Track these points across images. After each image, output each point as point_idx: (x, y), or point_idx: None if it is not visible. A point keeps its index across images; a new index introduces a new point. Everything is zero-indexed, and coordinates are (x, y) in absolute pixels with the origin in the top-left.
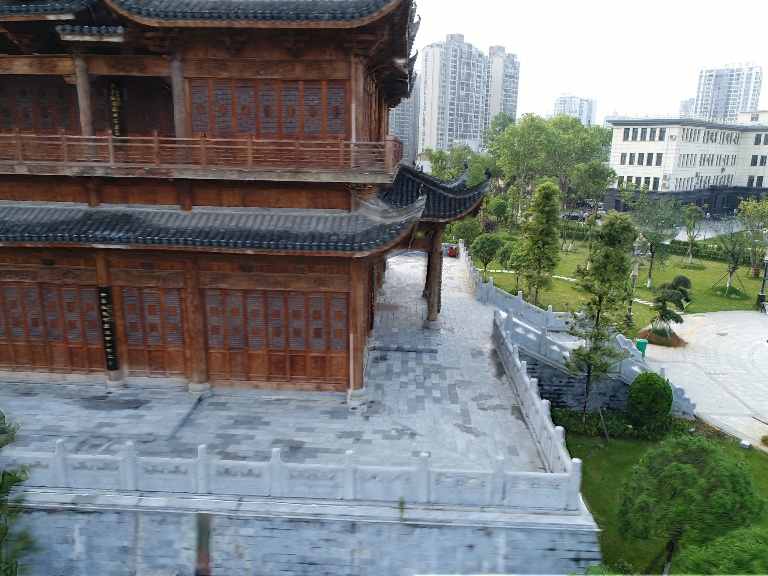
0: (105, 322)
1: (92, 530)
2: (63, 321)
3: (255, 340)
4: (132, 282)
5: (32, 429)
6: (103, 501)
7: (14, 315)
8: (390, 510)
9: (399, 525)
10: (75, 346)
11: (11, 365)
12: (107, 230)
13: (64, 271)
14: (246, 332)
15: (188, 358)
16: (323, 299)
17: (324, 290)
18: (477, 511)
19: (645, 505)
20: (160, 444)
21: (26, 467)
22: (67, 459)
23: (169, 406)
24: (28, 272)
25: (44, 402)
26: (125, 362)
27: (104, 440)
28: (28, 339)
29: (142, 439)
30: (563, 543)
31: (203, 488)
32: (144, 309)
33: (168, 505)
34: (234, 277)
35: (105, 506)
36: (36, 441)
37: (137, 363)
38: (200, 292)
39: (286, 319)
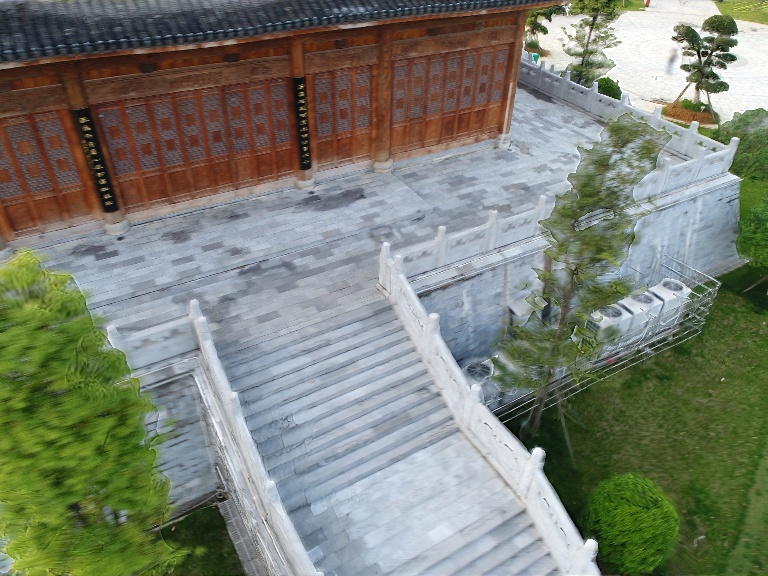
0: (302, 118)
1: (476, 290)
2: (250, 127)
3: (433, 106)
4: (327, 66)
5: (317, 240)
6: (480, 265)
7: (191, 133)
8: (646, 205)
9: (655, 212)
10: (263, 153)
11: (190, 193)
12: (342, 6)
13: (253, 66)
14: (426, 100)
15: (374, 139)
16: (492, 53)
17: (495, 44)
18: (685, 189)
19: (746, 159)
20: (433, 217)
21: (414, 260)
22: (449, 241)
23: (386, 187)
24: (209, 75)
25: (272, 217)
26: (314, 158)
27: (386, 229)
28: (209, 158)
29: (413, 218)
30: (726, 194)
31: (539, 230)
32: (335, 95)
33: (525, 250)
34: (423, 43)
35: (484, 267)
36: (332, 249)
37: (325, 156)
38: (391, 65)
39: (460, 79)
